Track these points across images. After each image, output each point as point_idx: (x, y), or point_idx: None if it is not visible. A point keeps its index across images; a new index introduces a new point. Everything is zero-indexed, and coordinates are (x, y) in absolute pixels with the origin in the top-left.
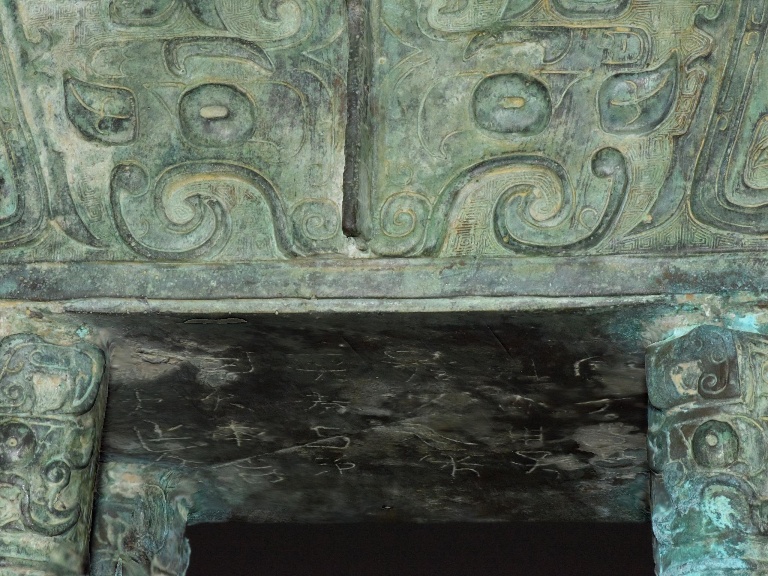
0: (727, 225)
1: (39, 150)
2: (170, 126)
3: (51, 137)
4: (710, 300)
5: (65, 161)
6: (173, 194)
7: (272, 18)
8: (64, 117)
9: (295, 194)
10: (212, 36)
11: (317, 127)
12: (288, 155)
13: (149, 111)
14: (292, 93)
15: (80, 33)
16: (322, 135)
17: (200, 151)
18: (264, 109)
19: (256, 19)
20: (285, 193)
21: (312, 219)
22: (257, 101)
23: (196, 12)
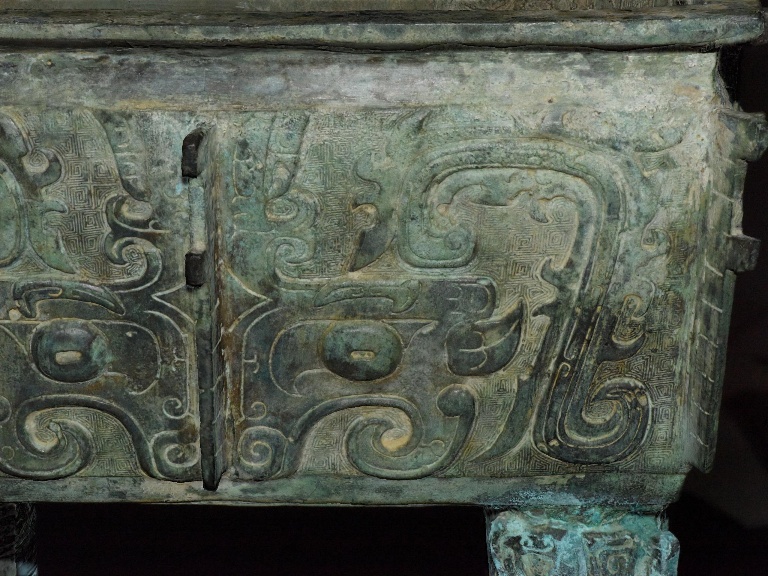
0: None
1: None
2: None
3: None
4: None
5: None
6: None
7: None
8: None
9: None
10: None
11: None
12: None
13: None
14: None
15: None
16: None
17: None
18: None
19: None
20: None
21: None
22: None
23: None
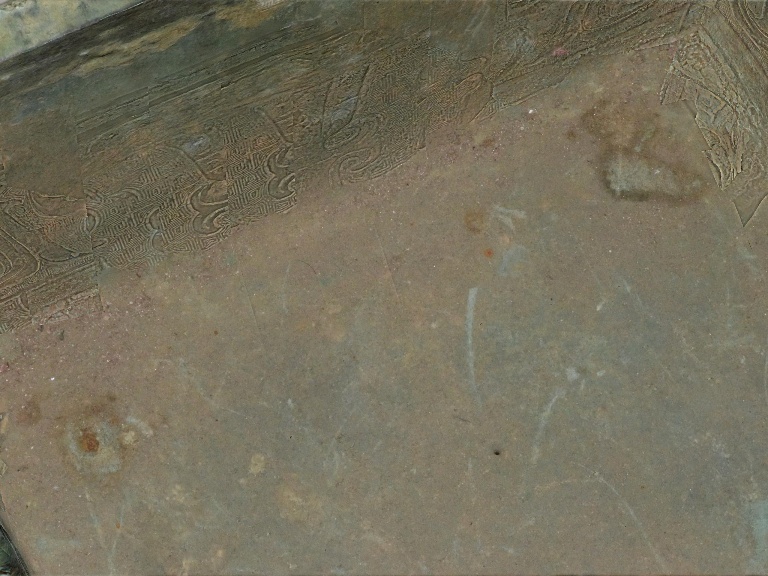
0: (7, 281)
1: None
2: None
3: None
4: (38, 319)
5: (571, 6)
6: None
7: None
8: None
9: None
10: None
11: None
12: None
13: (497, 8)
14: None
15: None
16: None
17: None
18: None
19: None
20: None
21: None
22: None
23: None
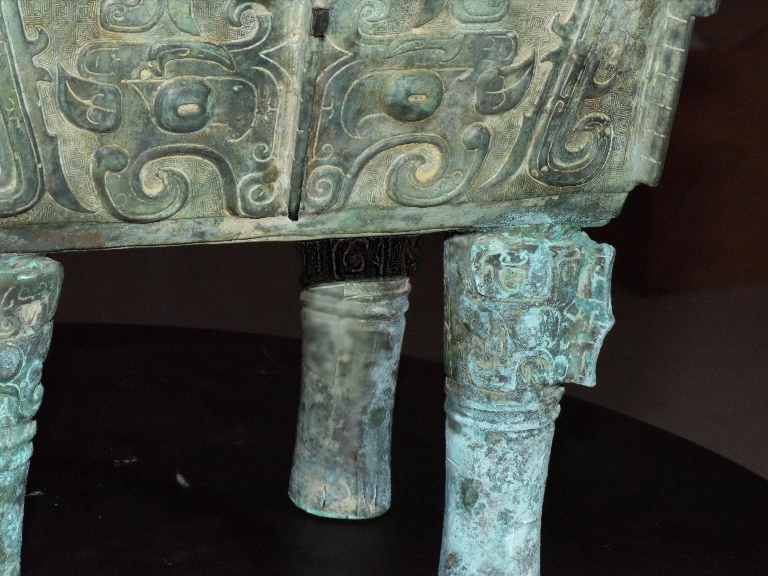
0: None
1: None
2: None
3: None
4: None
5: None
6: None
7: None
8: None
9: None
10: None
11: None
12: None
13: None
14: None
15: None
16: None
17: None
18: None
19: None
20: None
21: None
22: None
23: None
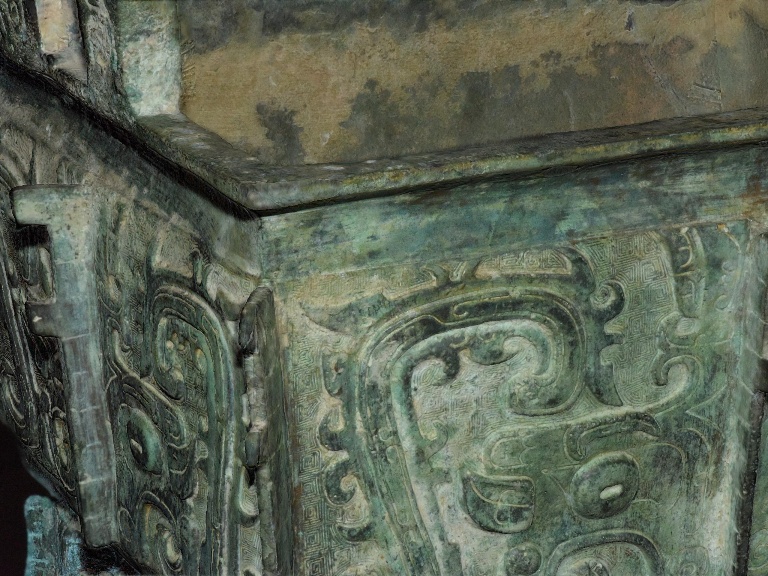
0: None
1: (434, 545)
2: (564, 505)
3: (445, 529)
4: None
5: (460, 552)
6: (560, 564)
7: (663, 384)
8: (458, 508)
9: (672, 547)
10: (611, 415)
11: (693, 480)
12: (665, 509)
13: (546, 495)
14: (675, 453)
15: (477, 423)
16: (697, 487)
17: (590, 524)
18: (647, 470)
19: (647, 386)
20: (663, 548)
21: (687, 569)
22: (642, 464)
23: (597, 394)
